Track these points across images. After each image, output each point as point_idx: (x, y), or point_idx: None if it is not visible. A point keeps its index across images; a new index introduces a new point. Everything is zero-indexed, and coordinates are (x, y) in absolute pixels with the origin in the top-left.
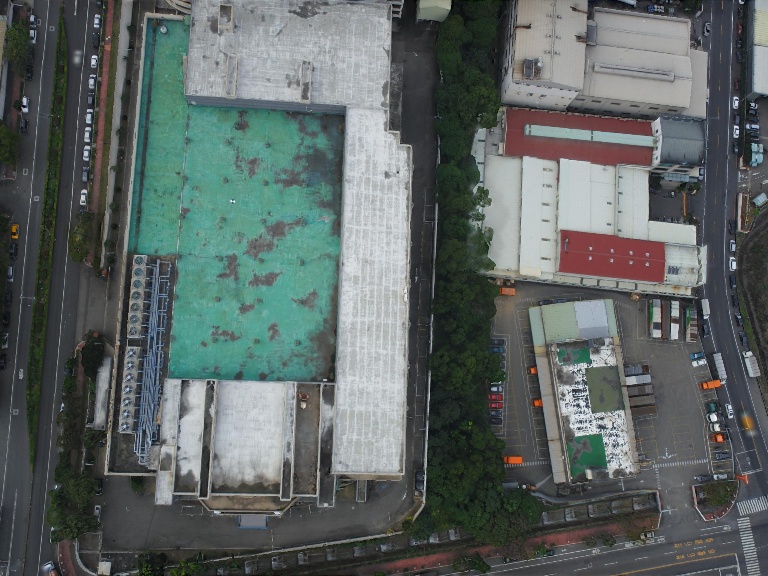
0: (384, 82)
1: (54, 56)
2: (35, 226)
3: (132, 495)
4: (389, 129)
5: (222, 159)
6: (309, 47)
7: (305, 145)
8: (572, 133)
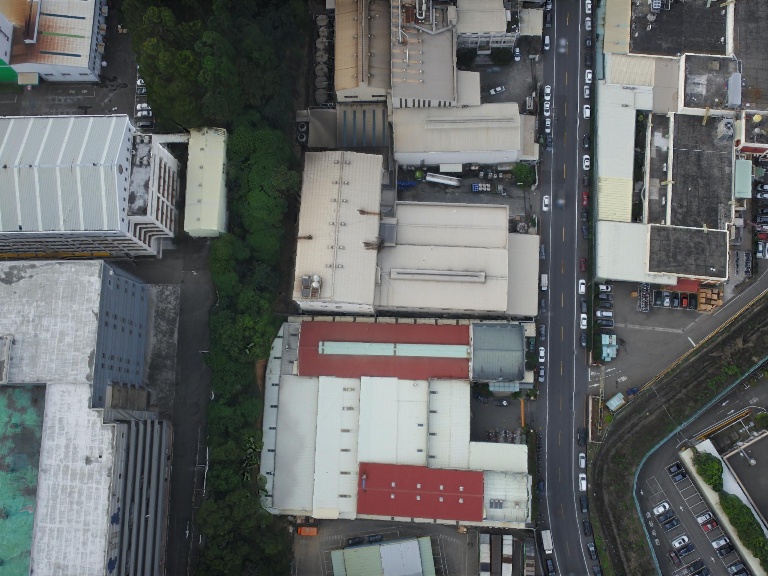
0: (91, 351)
1: None
2: None
3: None
4: (92, 407)
5: None
6: (11, 317)
7: None
8: (371, 348)
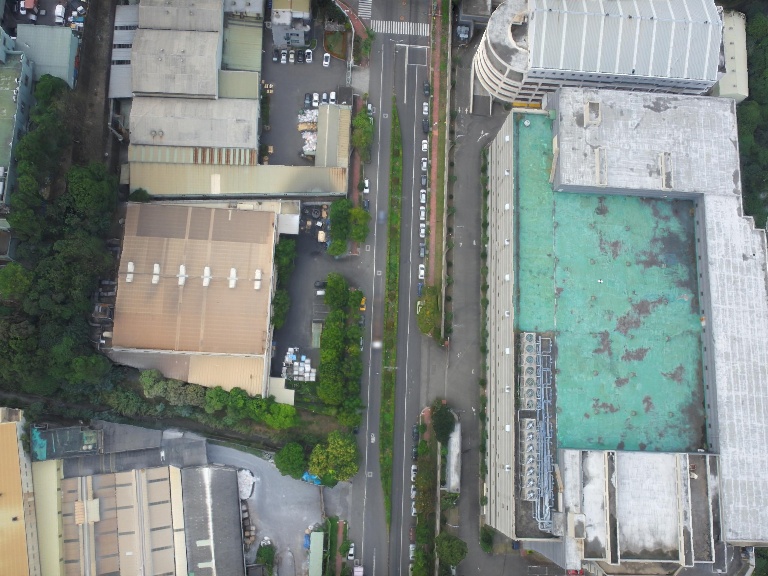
0: (734, 171)
1: (389, 141)
2: (379, 299)
3: (482, 555)
4: (744, 214)
5: (587, 242)
6: (665, 139)
7: (662, 229)
8: None
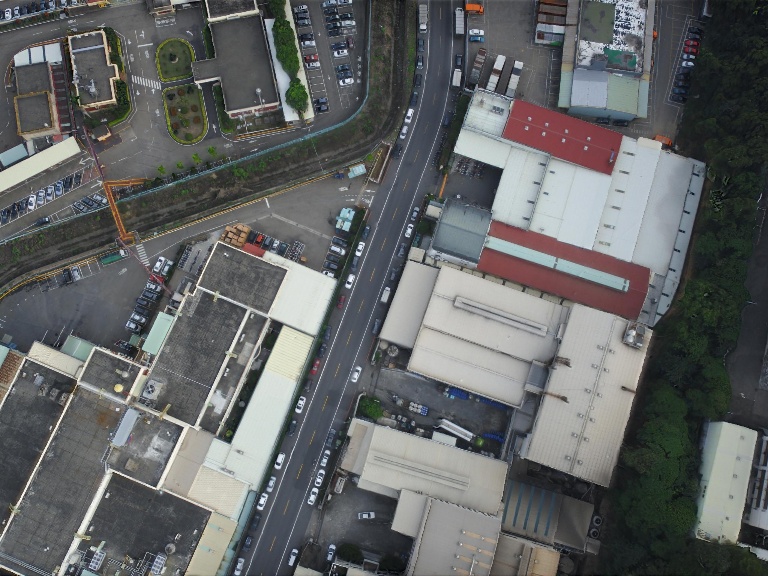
0: None
1: None
2: None
3: None
4: None
5: None
6: None
7: None
8: (579, 270)
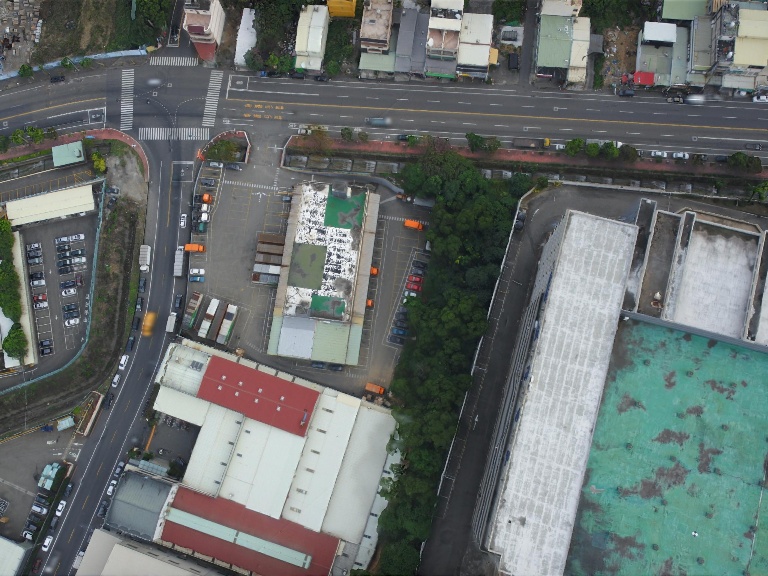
0: None
1: None
2: None
3: None
4: None
5: None
6: None
7: None
8: (258, 546)
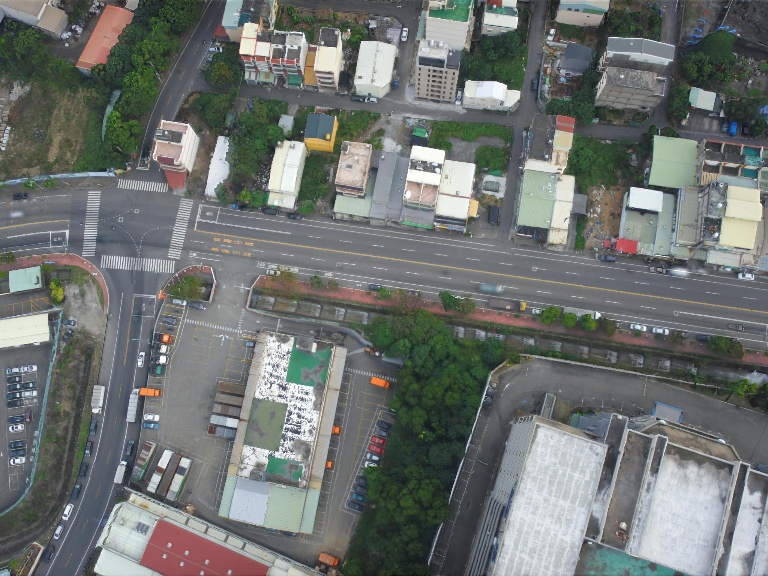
0: None
1: None
2: None
3: None
4: None
5: None
6: None
7: None
8: None
